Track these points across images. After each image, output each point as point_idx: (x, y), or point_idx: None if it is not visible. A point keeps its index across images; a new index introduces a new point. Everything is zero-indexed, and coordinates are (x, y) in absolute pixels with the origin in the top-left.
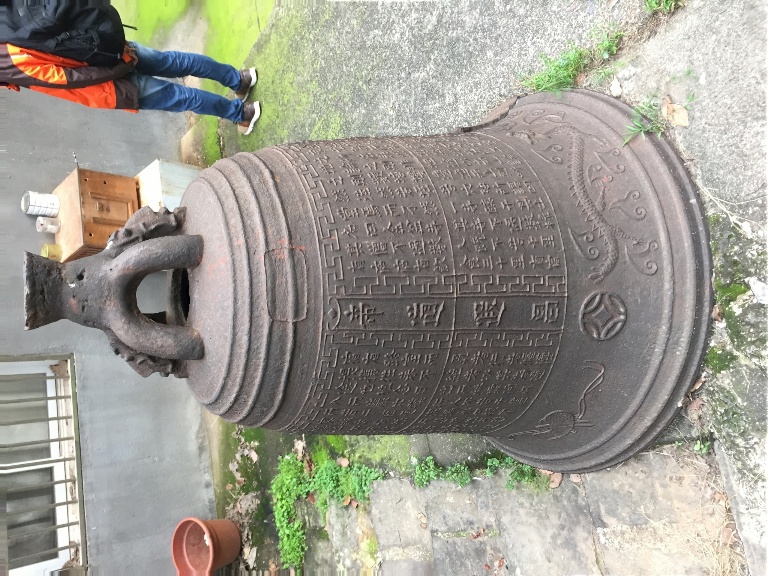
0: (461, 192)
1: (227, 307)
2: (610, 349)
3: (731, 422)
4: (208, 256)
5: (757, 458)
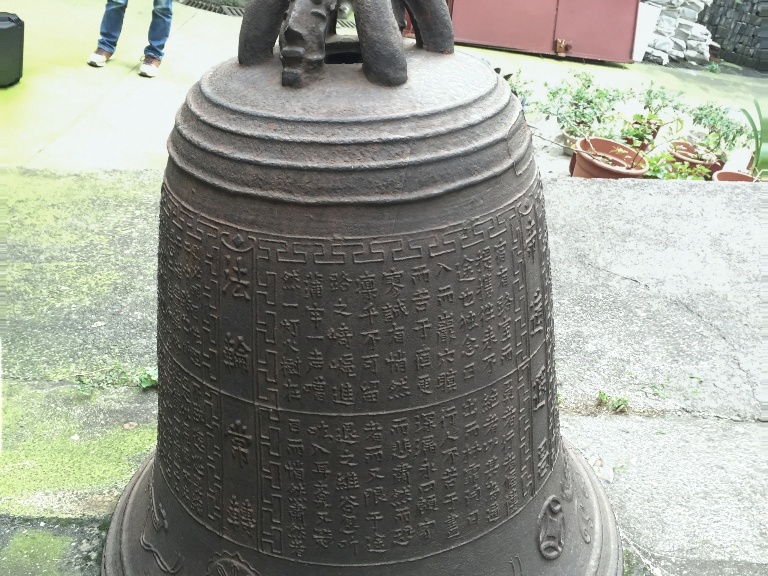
0: None
1: (474, 89)
2: (535, 570)
3: None
4: (458, 59)
5: None
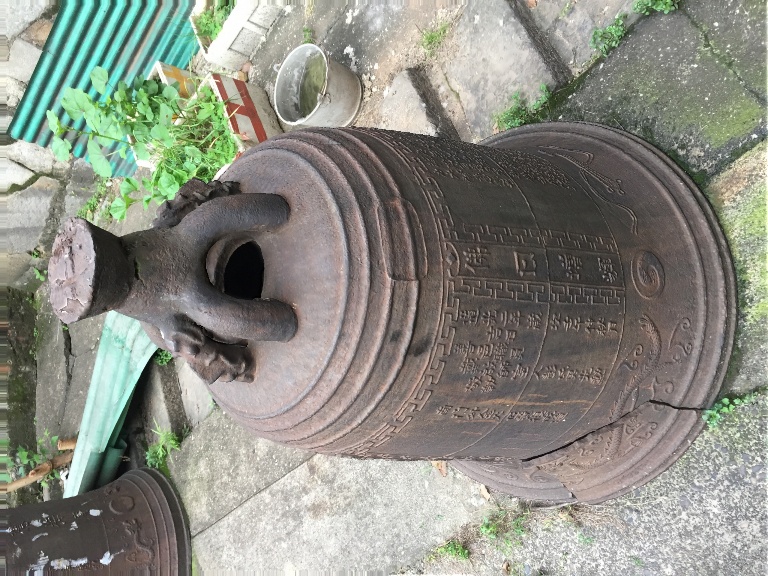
0: None
1: None
2: None
3: None
4: None
5: None
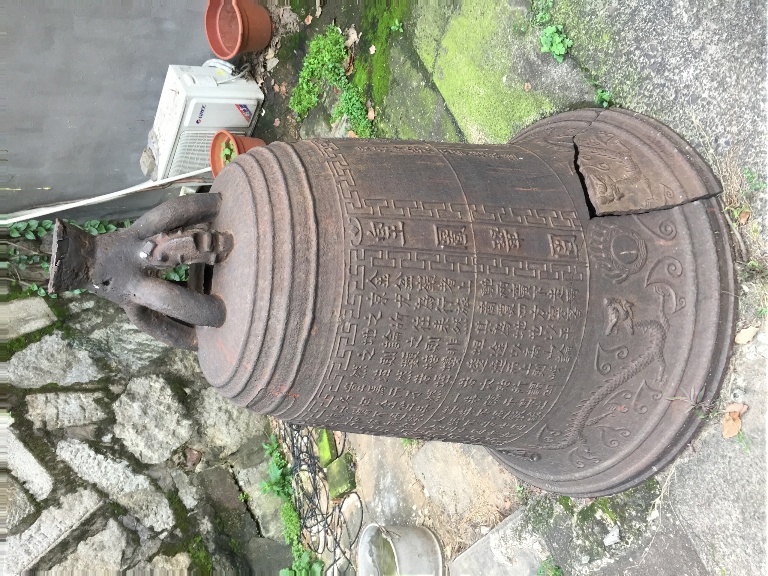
0: (477, 386)
1: (220, 376)
2: None
3: (537, 519)
4: (223, 335)
5: (529, 538)
